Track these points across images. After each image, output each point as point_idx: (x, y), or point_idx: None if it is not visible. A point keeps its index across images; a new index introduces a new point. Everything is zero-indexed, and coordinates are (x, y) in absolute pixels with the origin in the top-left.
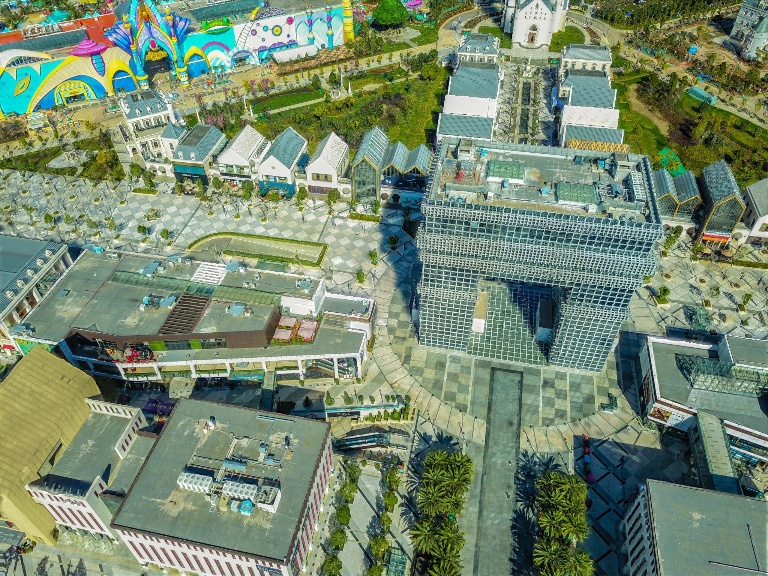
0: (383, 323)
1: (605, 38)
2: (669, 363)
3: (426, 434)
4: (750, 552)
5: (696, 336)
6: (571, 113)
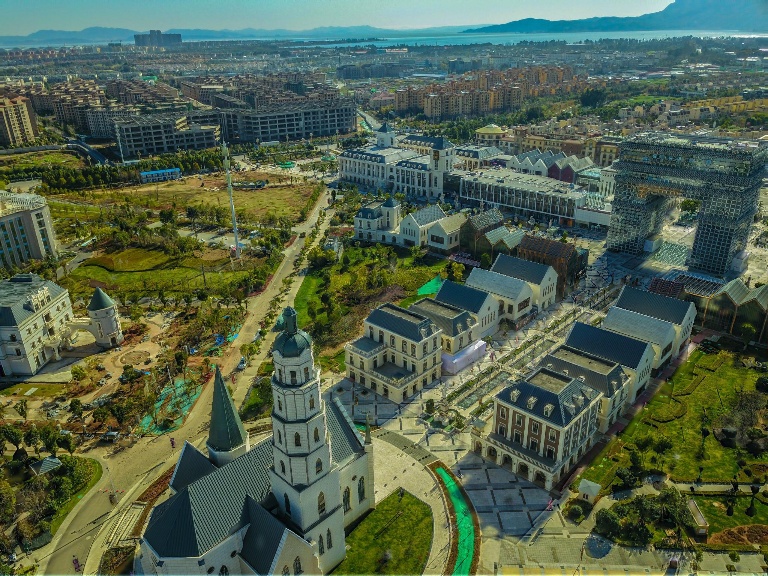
0: None
1: (174, 456)
2: (607, 210)
3: None
4: None
5: None
6: None
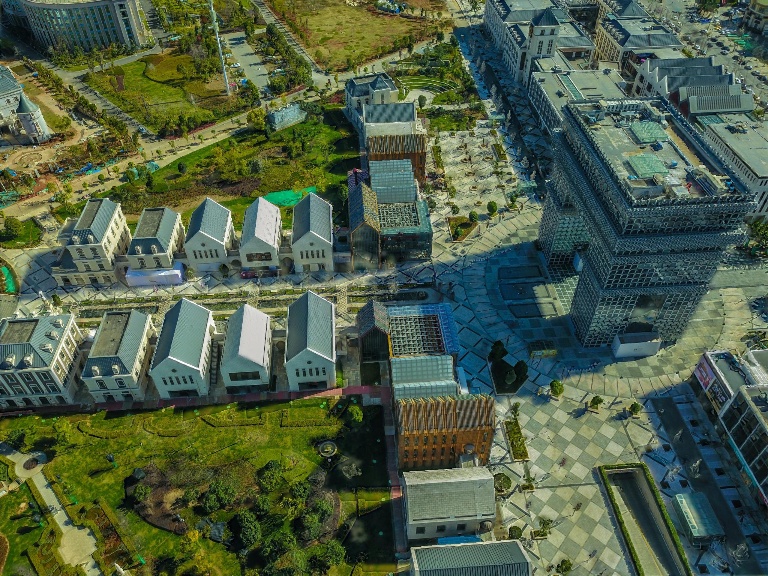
0: (676, 377)
1: None
2: None
3: (765, 321)
4: (766, 149)
5: (540, 194)
6: (263, 234)
